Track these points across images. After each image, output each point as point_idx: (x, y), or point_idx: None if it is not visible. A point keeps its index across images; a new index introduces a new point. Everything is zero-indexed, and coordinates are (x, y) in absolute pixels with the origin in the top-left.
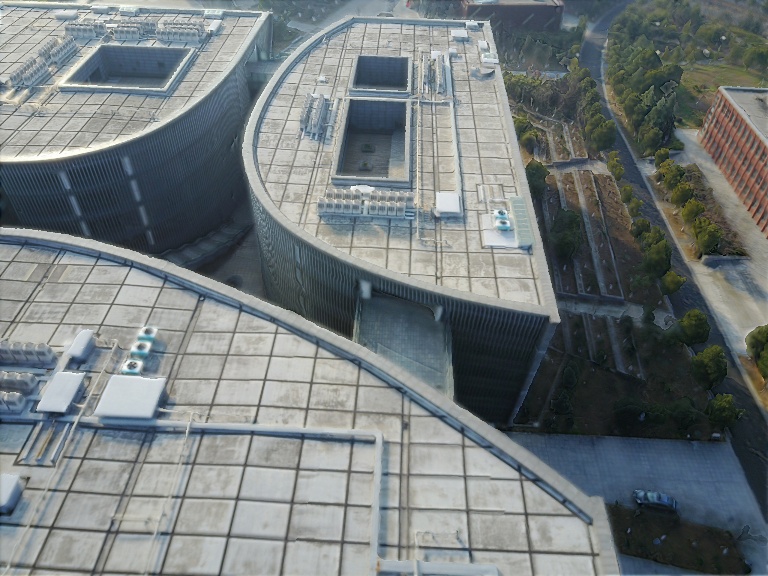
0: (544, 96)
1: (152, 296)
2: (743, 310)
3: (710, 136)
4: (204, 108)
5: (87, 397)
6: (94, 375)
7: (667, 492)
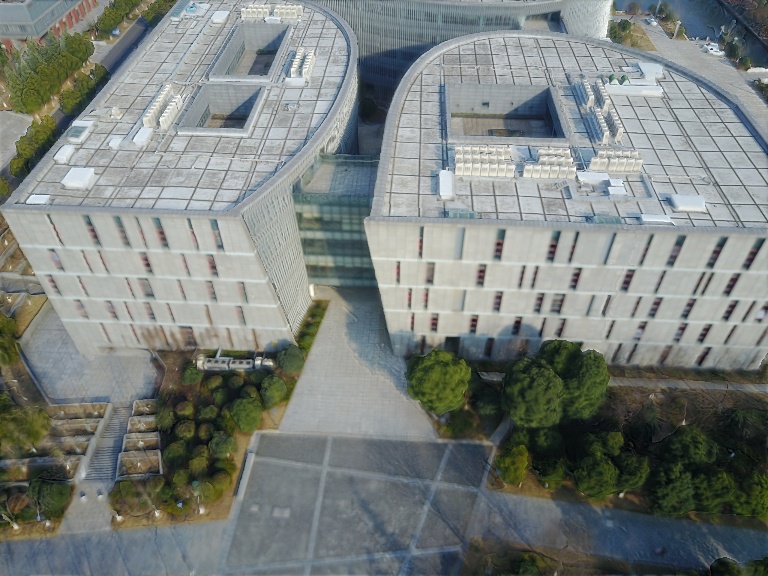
0: None
1: None
2: (3, 139)
3: None
4: None
5: None
6: None
7: None
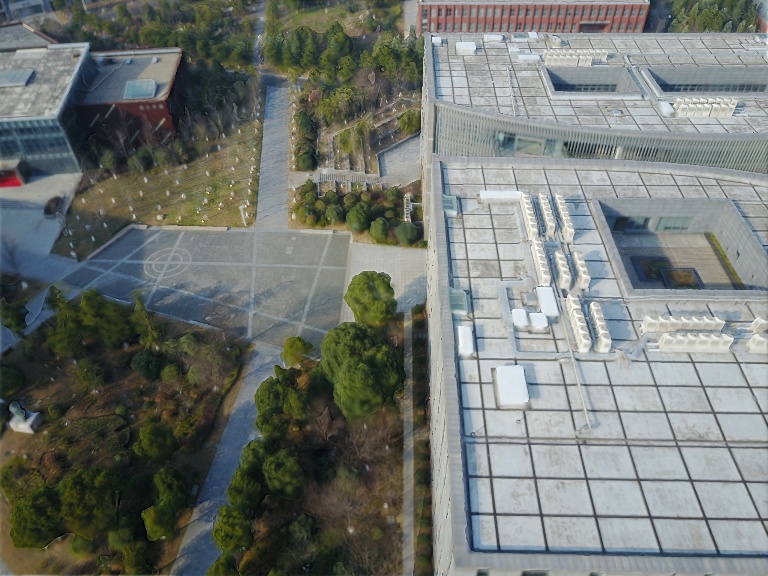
0: (378, 91)
1: None
2: None
3: None
4: None
5: None
6: None
7: None
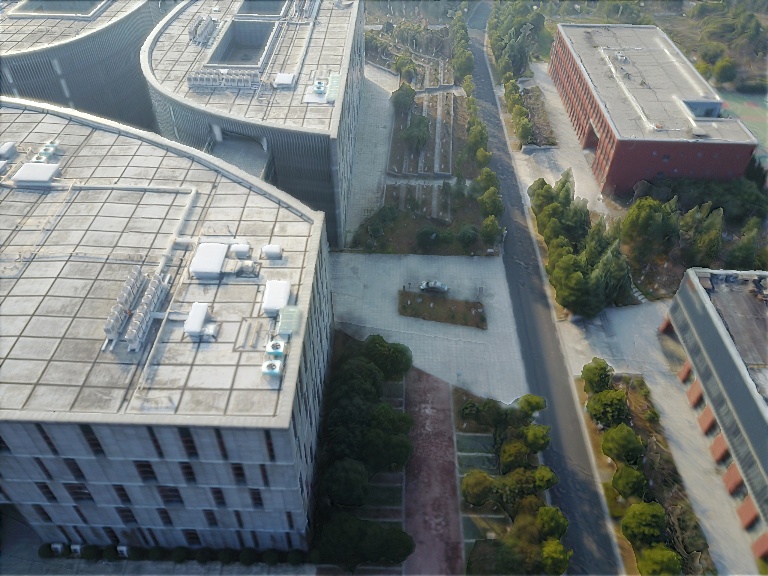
0: (424, 38)
1: (59, 128)
2: None
3: (553, 65)
4: (120, 29)
5: (7, 173)
6: (14, 165)
7: (446, 284)
